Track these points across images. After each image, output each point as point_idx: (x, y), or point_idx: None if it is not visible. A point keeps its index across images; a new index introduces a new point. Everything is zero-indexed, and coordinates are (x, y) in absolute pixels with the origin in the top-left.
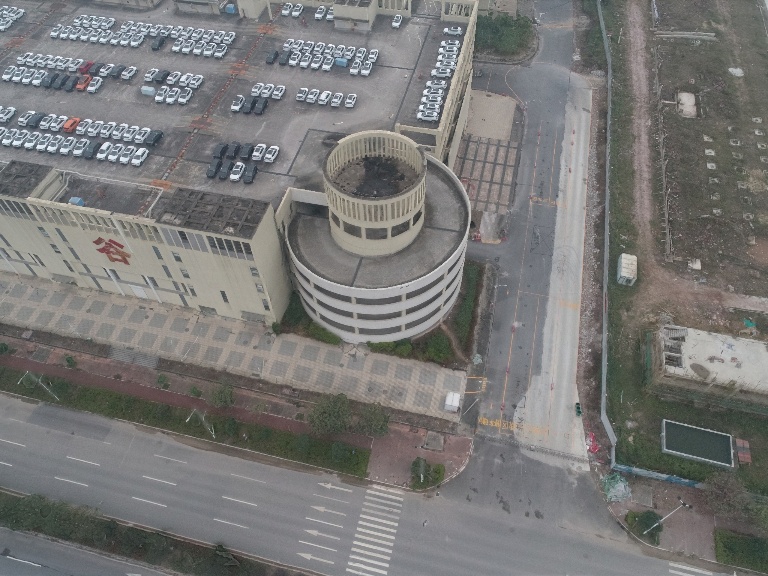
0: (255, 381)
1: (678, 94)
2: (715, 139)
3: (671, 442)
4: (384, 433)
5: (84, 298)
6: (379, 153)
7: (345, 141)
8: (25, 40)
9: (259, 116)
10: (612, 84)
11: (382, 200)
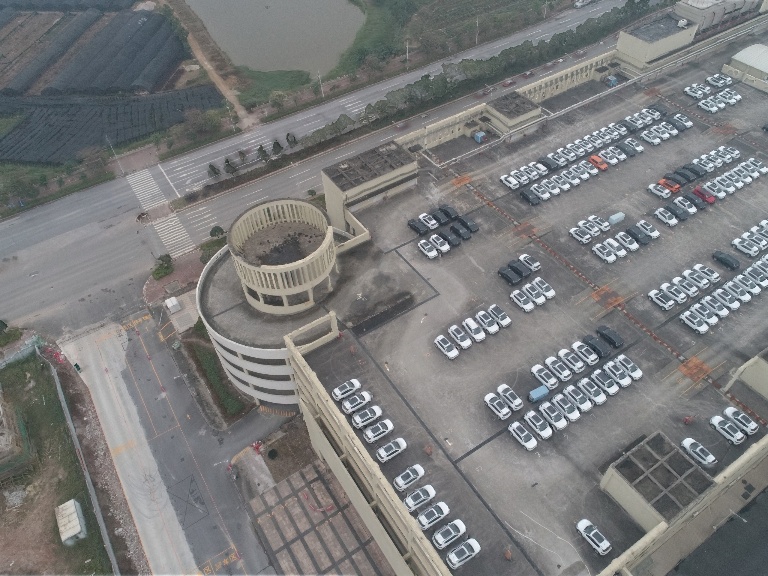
0: None
1: None
2: None
3: None
4: None
5: None
6: None
7: (328, 232)
8: None
9: None
10: None
11: None
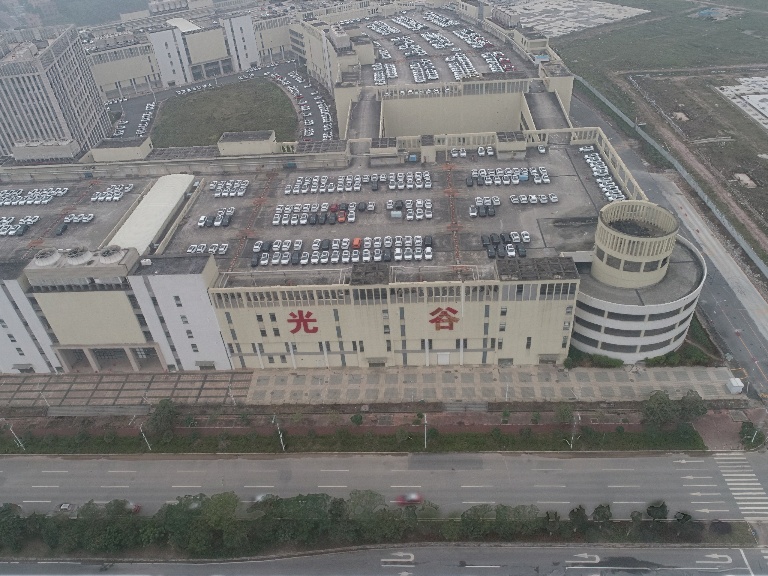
0: (575, 403)
1: (734, 175)
2: None
3: None
4: (698, 418)
5: (395, 374)
6: (619, 218)
7: (604, 210)
8: (266, 199)
9: (493, 217)
10: None
11: (665, 236)
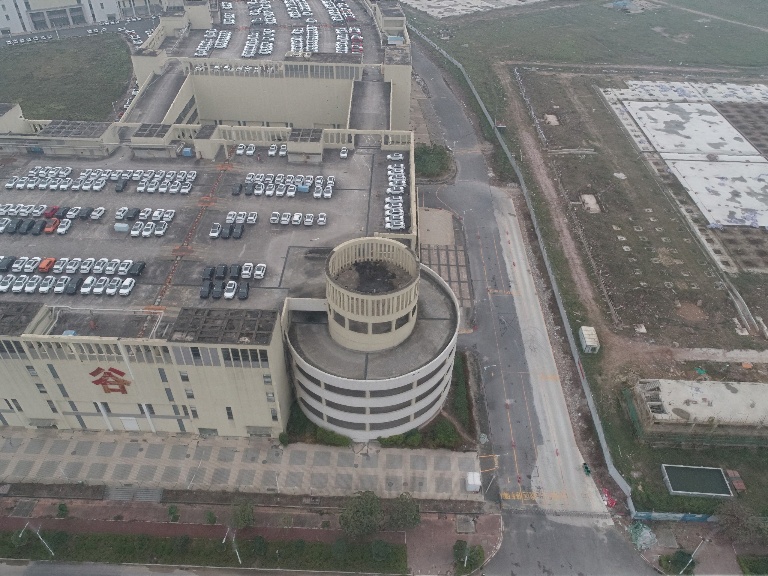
0: (272, 496)
1: (581, 196)
2: (622, 228)
3: (675, 484)
4: (415, 525)
5: (66, 440)
6: (367, 258)
7: (339, 249)
8: None
9: (238, 240)
10: (527, 193)
11: (390, 294)
